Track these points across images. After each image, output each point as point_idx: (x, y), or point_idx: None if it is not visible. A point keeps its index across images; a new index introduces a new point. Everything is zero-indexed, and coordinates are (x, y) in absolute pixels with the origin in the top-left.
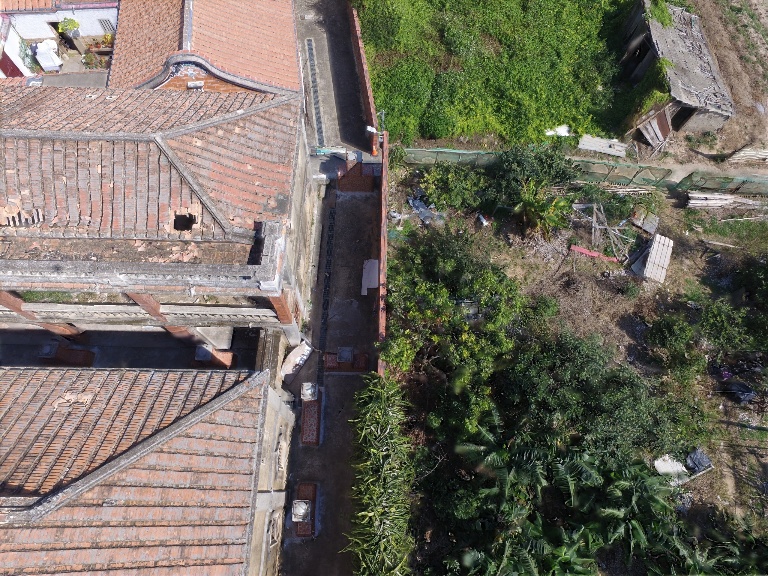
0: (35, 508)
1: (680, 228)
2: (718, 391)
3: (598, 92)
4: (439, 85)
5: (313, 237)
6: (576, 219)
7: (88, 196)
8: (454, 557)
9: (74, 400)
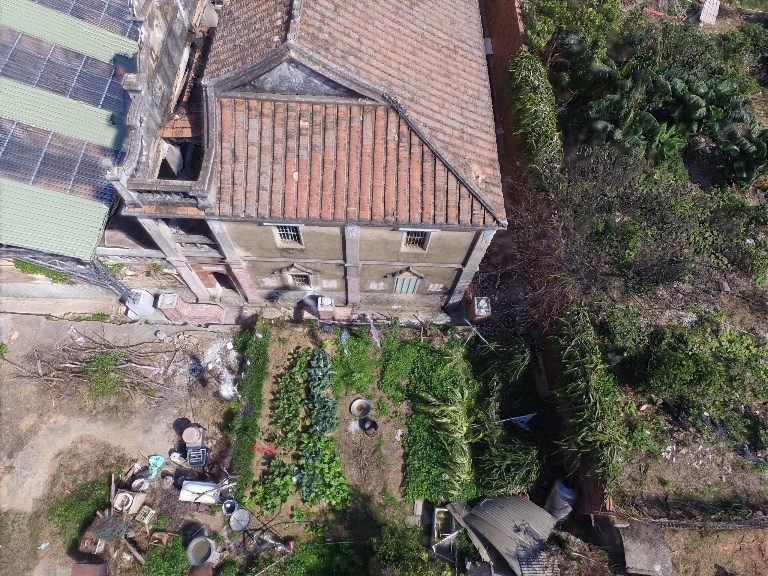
0: None
1: (723, 2)
2: (758, 84)
3: None
4: None
5: None
6: None
7: None
8: (589, 144)
9: None
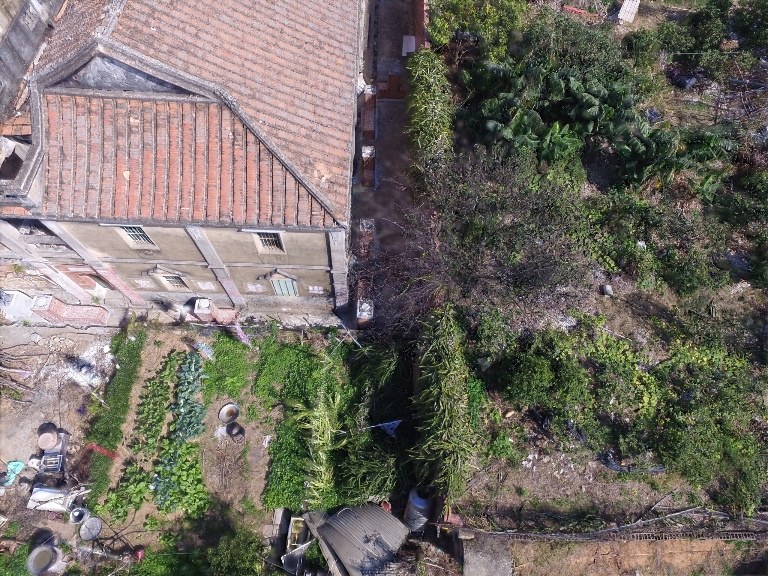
0: None
1: None
2: (671, 83)
3: None
4: None
5: (363, 21)
6: None
7: None
8: (482, 143)
9: None
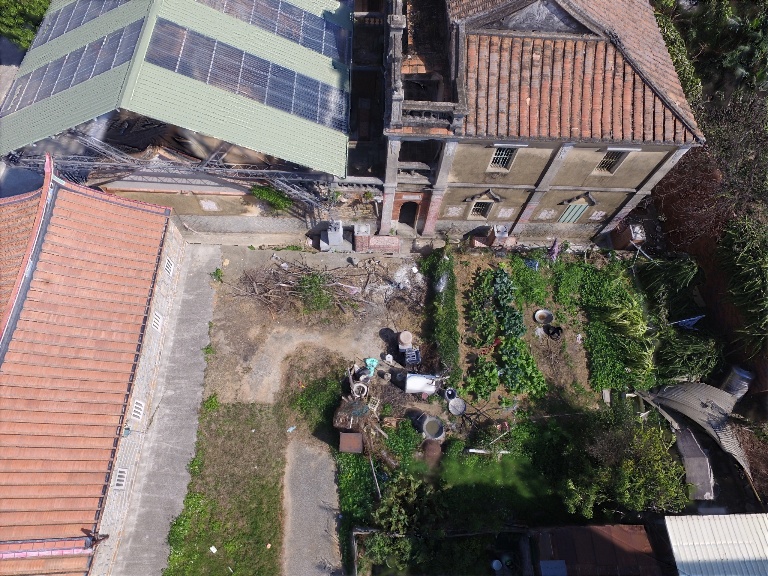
0: None
1: None
2: None
3: None
4: None
5: None
6: None
7: None
8: (722, 90)
9: None
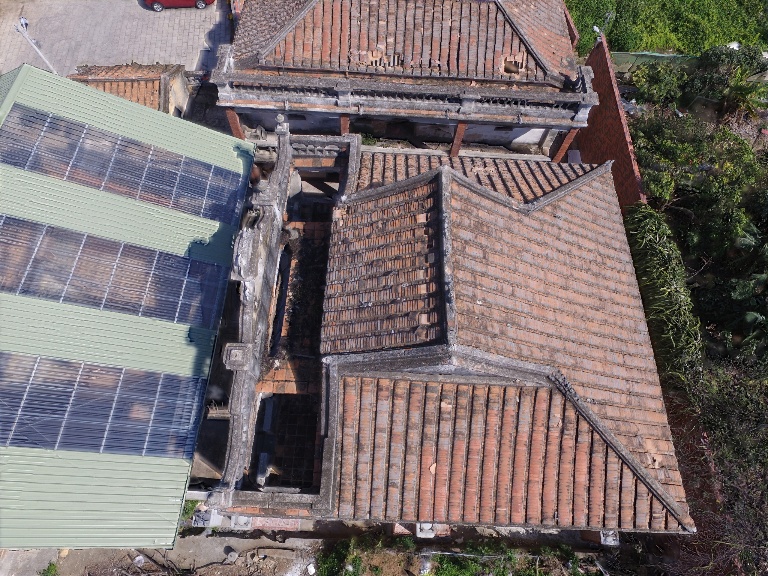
0: (530, 204)
1: None
2: None
3: (761, 16)
4: (622, 8)
5: None
6: (762, 110)
7: (439, 44)
8: (729, 330)
9: (483, 171)
